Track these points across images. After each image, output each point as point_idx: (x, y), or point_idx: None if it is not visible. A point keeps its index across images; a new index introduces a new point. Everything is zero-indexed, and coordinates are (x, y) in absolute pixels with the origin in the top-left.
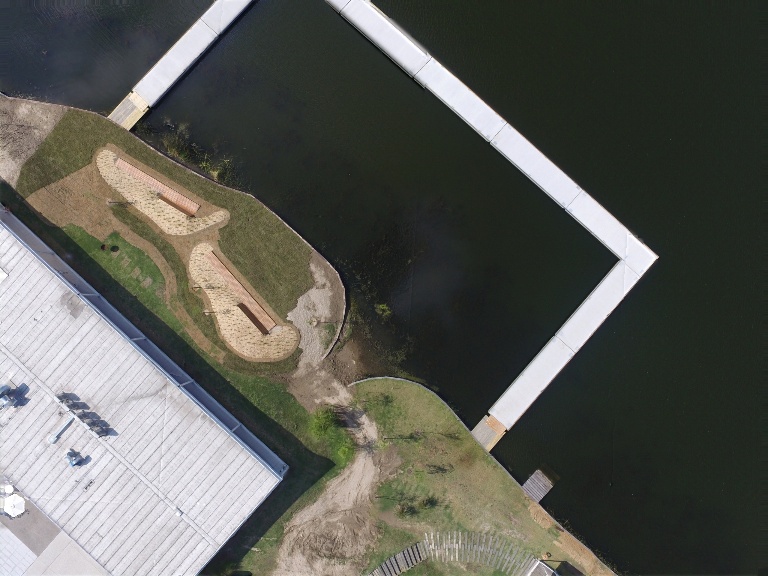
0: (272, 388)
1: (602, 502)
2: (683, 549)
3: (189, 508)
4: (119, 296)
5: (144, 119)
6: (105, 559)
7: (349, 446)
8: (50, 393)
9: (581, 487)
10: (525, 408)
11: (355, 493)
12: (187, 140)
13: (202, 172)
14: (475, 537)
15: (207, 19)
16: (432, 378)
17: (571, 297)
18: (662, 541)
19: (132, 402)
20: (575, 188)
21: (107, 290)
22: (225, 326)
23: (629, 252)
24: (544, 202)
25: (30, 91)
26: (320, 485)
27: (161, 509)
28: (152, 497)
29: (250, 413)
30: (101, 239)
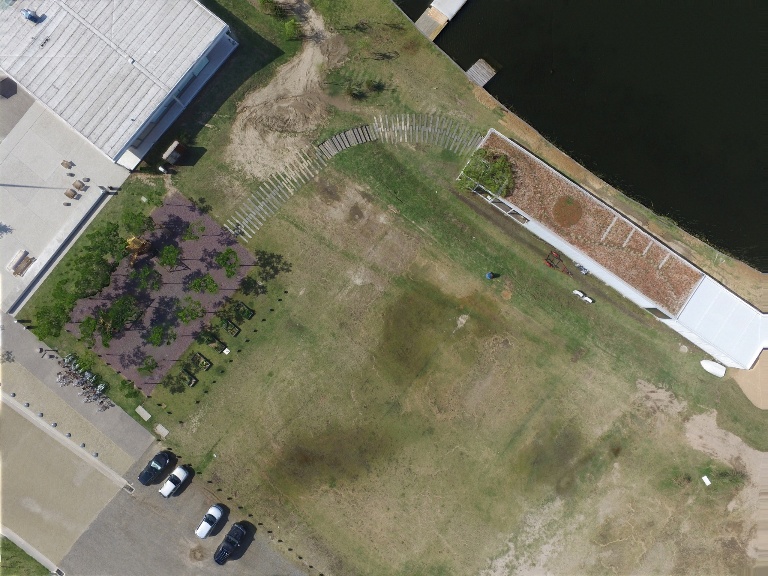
0: None
1: (545, 89)
2: (625, 130)
3: (140, 56)
4: None
5: None
6: (61, 109)
7: (298, 37)
8: None
9: (523, 75)
10: None
11: (305, 80)
12: None
13: None
14: (422, 119)
15: None
16: None
17: None
18: (605, 123)
19: None
20: None
21: None
22: None
23: None
24: None
25: None
26: (270, 70)
27: (114, 59)
28: (105, 48)
29: None
30: None
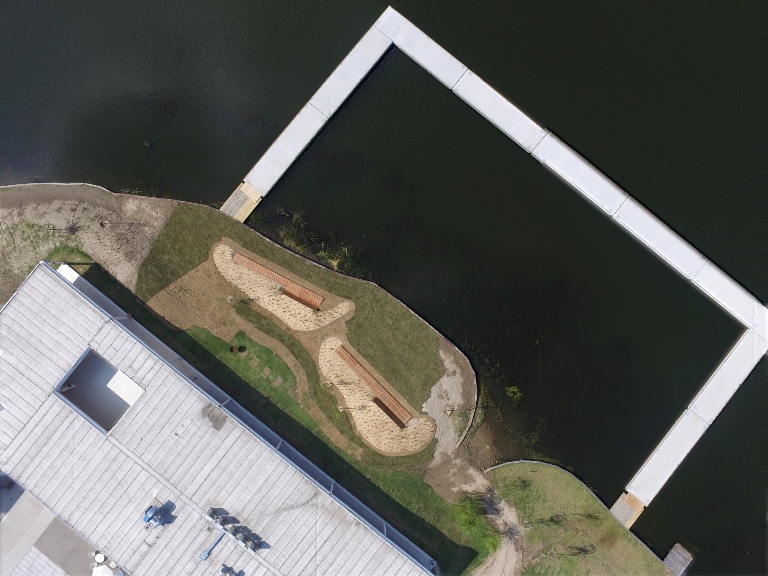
0: (410, 480)
1: (741, 570)
2: None
3: None
4: (251, 398)
5: (257, 209)
6: None
7: (490, 533)
8: (197, 509)
9: (720, 557)
10: (662, 483)
11: None
12: (303, 229)
13: (321, 261)
14: None
15: (316, 102)
16: (567, 458)
17: (701, 368)
18: None
19: (283, 513)
20: (701, 258)
21: (238, 393)
22: (361, 422)
23: (757, 320)
24: (668, 273)
25: (135, 185)
26: (465, 575)
27: None
28: None
29: (393, 510)
30: (227, 340)
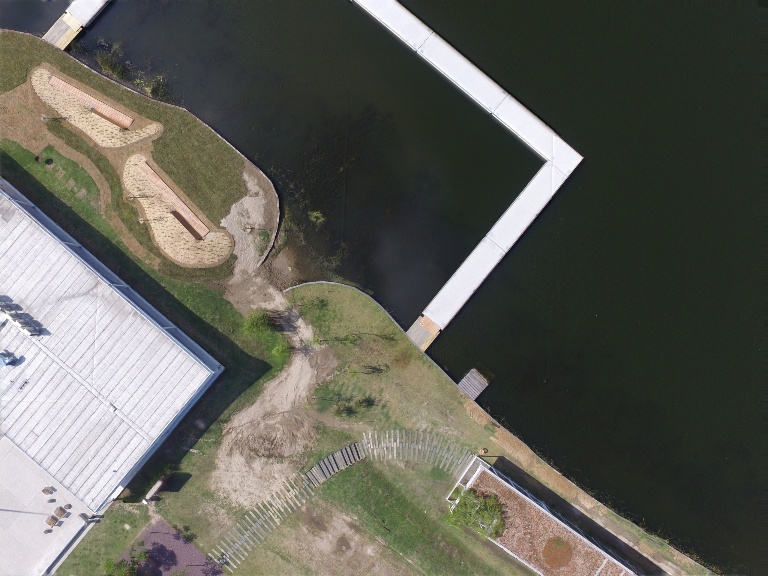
0: (208, 294)
1: (538, 399)
2: (619, 443)
3: (122, 404)
4: (54, 206)
5: (78, 39)
6: (41, 457)
7: (286, 349)
8: None
9: (516, 385)
10: (458, 308)
11: (293, 395)
12: None
13: (136, 89)
14: (412, 435)
15: None
16: (367, 282)
17: (501, 199)
18: (598, 435)
19: (64, 302)
20: (501, 93)
21: (42, 201)
22: (159, 233)
23: (556, 153)
24: (472, 109)
25: None
26: (257, 387)
27: (95, 406)
28: (86, 394)
29: (185, 316)
30: (36, 153)
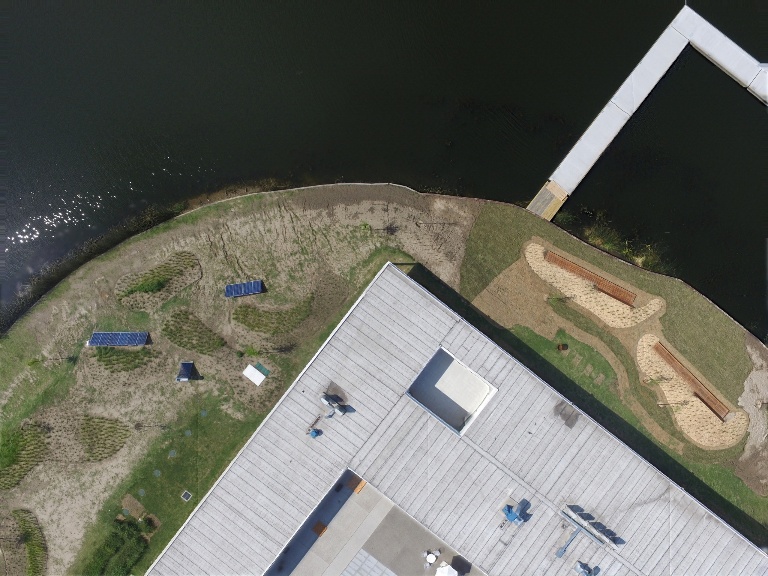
0: (724, 474)
1: None
2: None
3: None
4: (578, 396)
5: None
6: None
7: None
8: (553, 507)
9: None
10: None
11: None
12: None
13: (625, 259)
14: None
15: (619, 101)
16: None
17: None
18: None
19: (636, 509)
20: None
21: (565, 391)
22: (683, 417)
23: None
24: None
25: (437, 184)
26: None
27: None
28: None
29: (718, 503)
30: (550, 338)
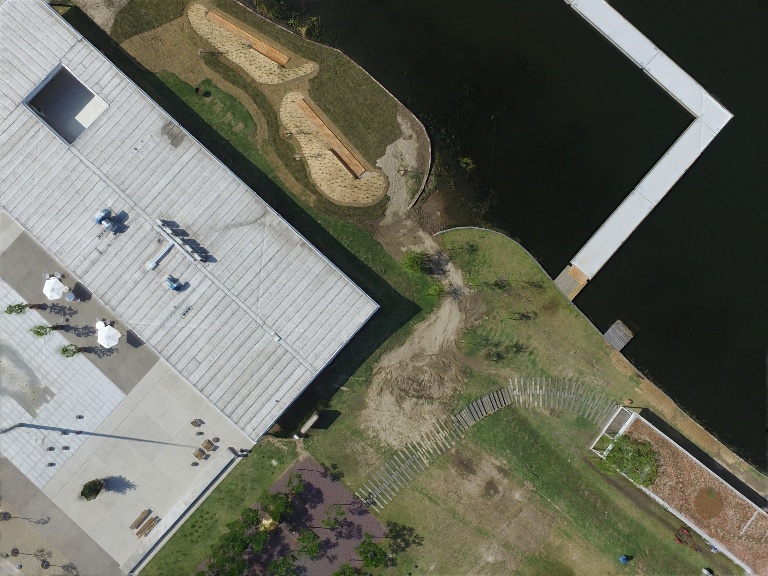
0: (360, 234)
1: (680, 353)
2: (759, 400)
3: (287, 334)
4: (212, 138)
5: None
6: (202, 384)
7: None
8: (150, 220)
9: (660, 338)
10: (606, 259)
11: (441, 338)
12: None
13: (290, 29)
14: (558, 383)
15: None
16: (515, 230)
17: (649, 154)
18: (739, 392)
19: (231, 230)
20: (653, 49)
21: (200, 133)
22: (316, 170)
23: (705, 110)
24: (622, 64)
25: None
26: (408, 328)
27: (259, 335)
28: (250, 323)
29: (341, 253)
30: (194, 85)
